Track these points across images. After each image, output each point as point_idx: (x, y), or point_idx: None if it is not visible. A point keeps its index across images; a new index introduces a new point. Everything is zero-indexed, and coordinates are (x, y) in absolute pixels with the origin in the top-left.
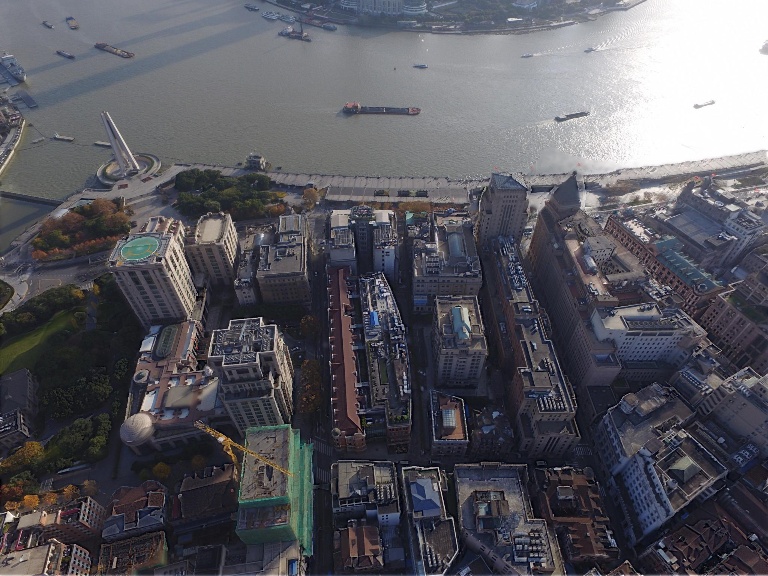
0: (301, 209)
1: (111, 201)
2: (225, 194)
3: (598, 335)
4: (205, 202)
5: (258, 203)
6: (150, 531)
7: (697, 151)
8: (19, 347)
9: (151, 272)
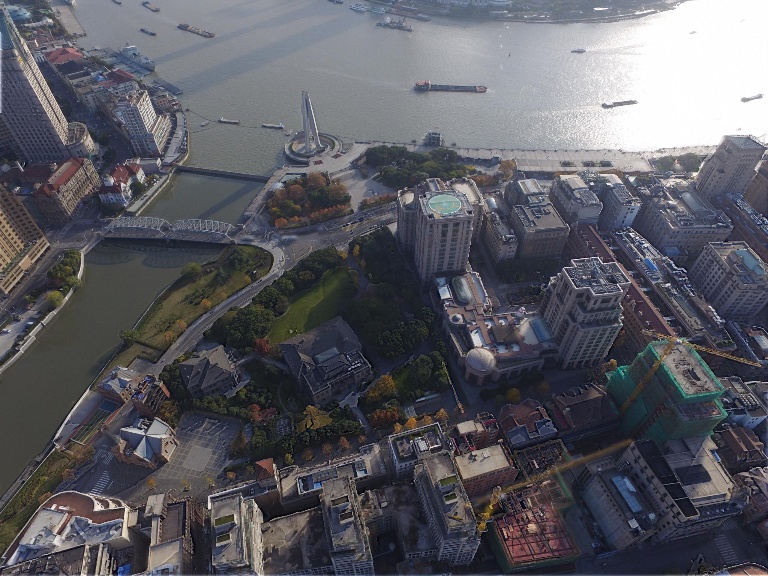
0: (498, 179)
1: (321, 175)
2: (428, 166)
3: None
4: (414, 173)
5: (462, 174)
6: (544, 440)
7: None
8: (307, 301)
9: (461, 224)
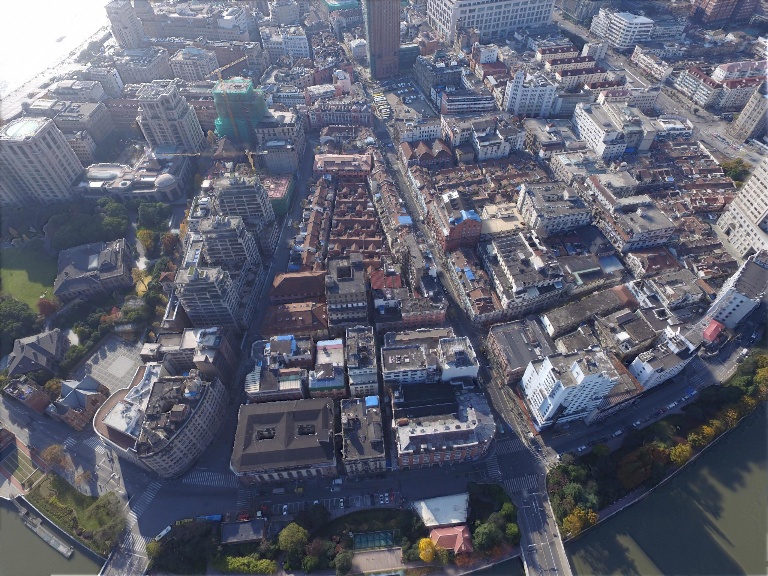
0: None
1: None
2: None
3: (229, 28)
4: None
5: None
6: None
7: None
8: (18, 282)
9: (51, 131)
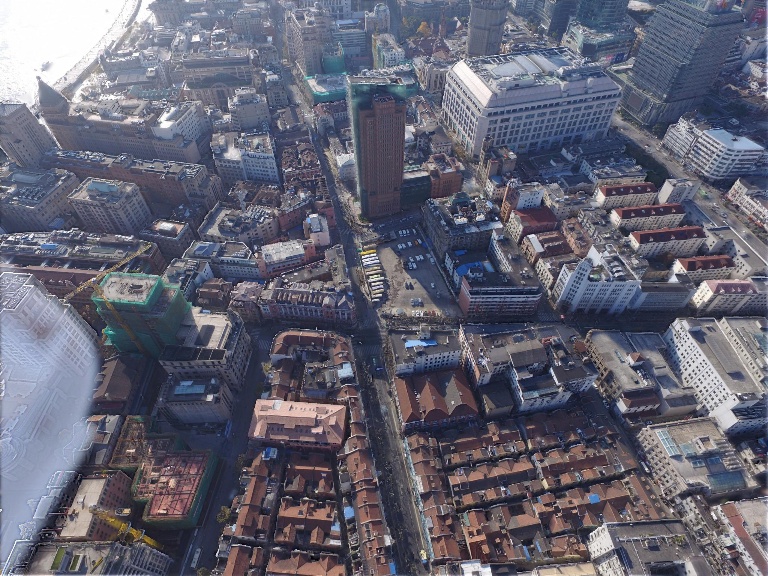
0: None
1: None
2: None
3: (168, 138)
4: None
5: None
6: None
7: (72, 56)
8: None
9: None
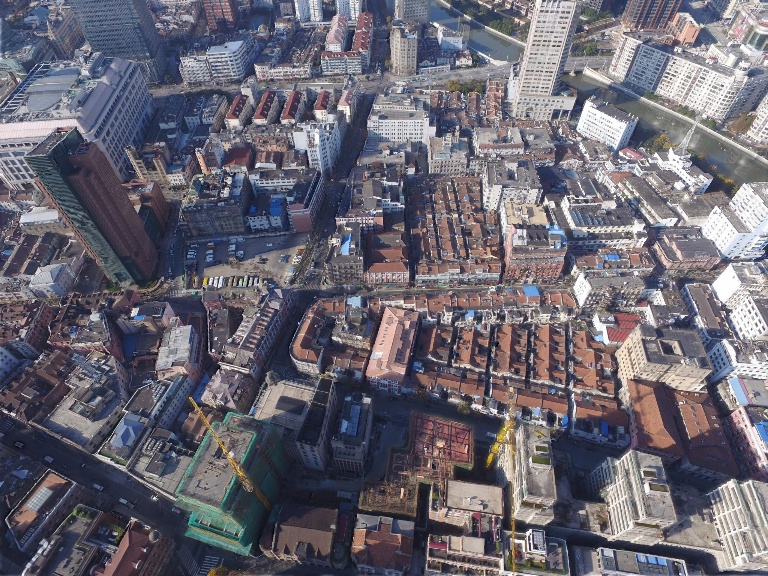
0: None
1: None
2: None
3: None
4: None
5: None
6: None
7: None
8: None
9: None
